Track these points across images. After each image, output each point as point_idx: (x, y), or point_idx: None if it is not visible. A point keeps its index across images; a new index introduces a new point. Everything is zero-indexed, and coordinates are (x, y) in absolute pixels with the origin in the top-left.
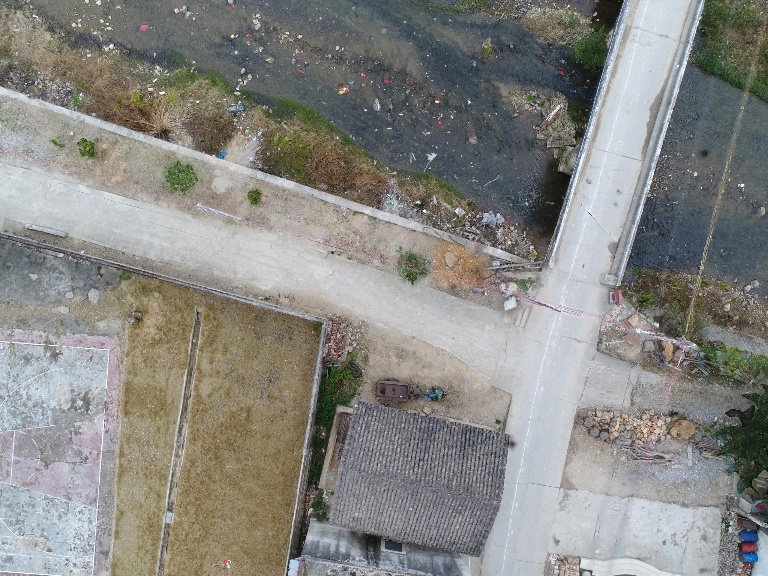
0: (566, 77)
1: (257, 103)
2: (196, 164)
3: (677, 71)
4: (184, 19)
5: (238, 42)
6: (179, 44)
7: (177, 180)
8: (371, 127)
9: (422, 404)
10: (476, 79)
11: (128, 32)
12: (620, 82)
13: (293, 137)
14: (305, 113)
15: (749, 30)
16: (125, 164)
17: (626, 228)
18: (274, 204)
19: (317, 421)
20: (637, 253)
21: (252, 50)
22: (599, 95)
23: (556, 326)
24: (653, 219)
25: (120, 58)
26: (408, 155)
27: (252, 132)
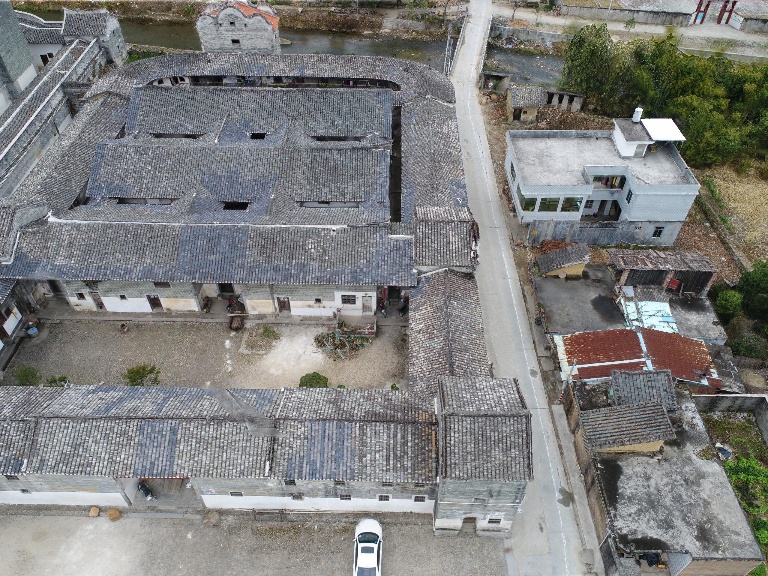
0: None
1: None
2: None
3: None
4: None
5: None
6: None
7: None
8: None
9: (521, 5)
10: None
11: None
12: None
13: None
14: None
15: None
16: None
17: None
18: None
19: (554, 4)
20: None
21: None
22: None
23: (483, 12)
24: None
25: None
26: None
27: None
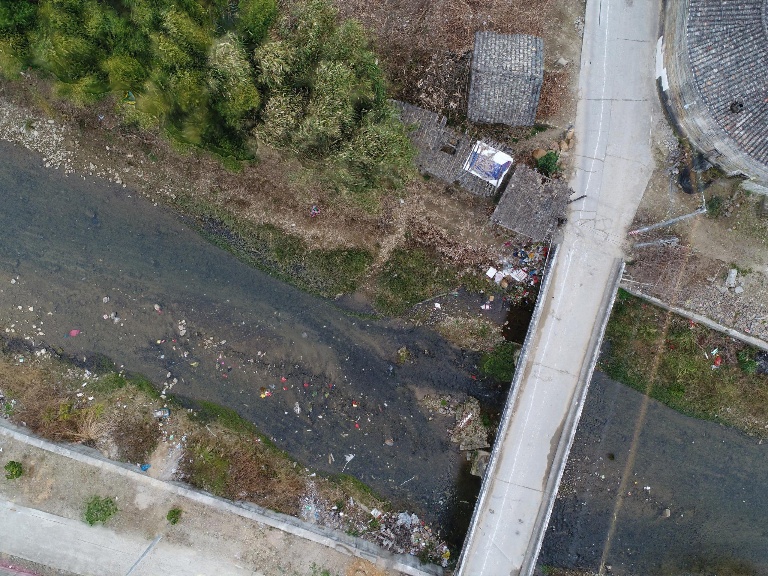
0: (479, 382)
1: (182, 406)
2: (120, 480)
3: (576, 408)
4: (113, 324)
5: (164, 347)
6: (108, 348)
7: (96, 518)
8: (291, 429)
9: None
10: (393, 382)
11: (59, 337)
12: (522, 416)
13: (216, 441)
14: (228, 416)
15: (654, 341)
16: (52, 480)
17: (527, 557)
18: (194, 520)
19: None
20: (547, 551)
21: (178, 354)
22: (499, 436)
23: None
24: (562, 519)
25: (51, 362)
26: (327, 456)
27: (176, 438)
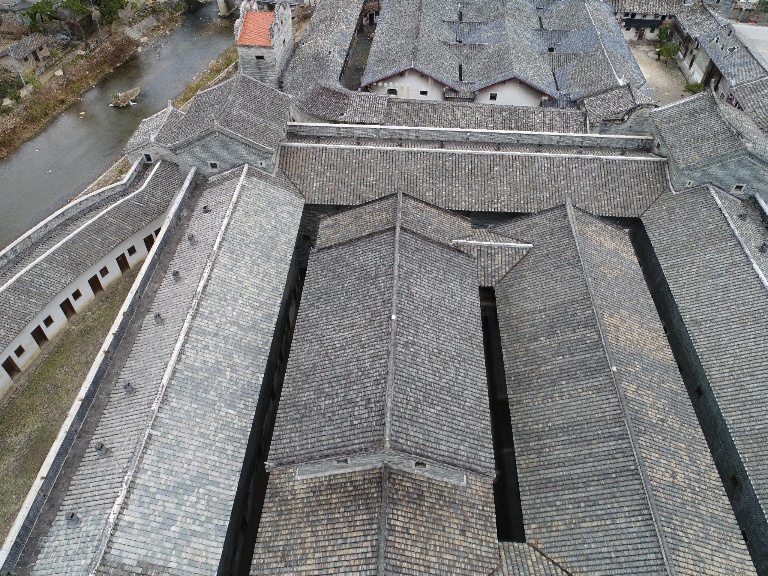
0: None
1: None
2: None
3: None
4: None
5: None
6: None
7: None
8: None
9: None
10: None
11: None
12: None
13: None
14: None
15: None
16: None
17: None
18: None
19: None
20: None
21: None
22: None
23: None
24: None
25: None
26: None
27: None
